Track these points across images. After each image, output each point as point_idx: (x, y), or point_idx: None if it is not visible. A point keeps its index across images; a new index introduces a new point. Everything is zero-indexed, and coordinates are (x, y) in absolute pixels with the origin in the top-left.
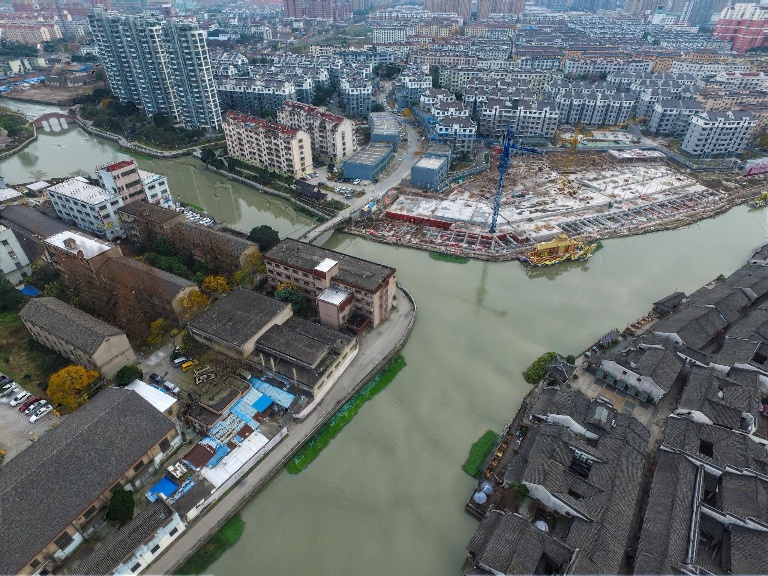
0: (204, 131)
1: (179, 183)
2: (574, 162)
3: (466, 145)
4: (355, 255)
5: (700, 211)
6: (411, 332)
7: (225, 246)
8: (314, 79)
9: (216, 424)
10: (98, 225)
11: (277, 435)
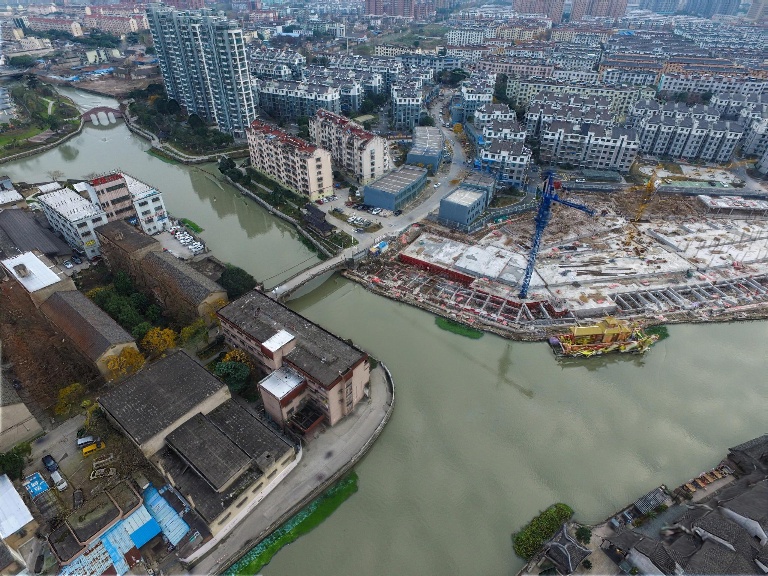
0: (237, 136)
1: (215, 185)
2: (650, 207)
3: (515, 176)
4: (348, 308)
5: None
6: (381, 434)
7: (186, 290)
8: (365, 84)
9: (74, 559)
10: (79, 242)
11: None
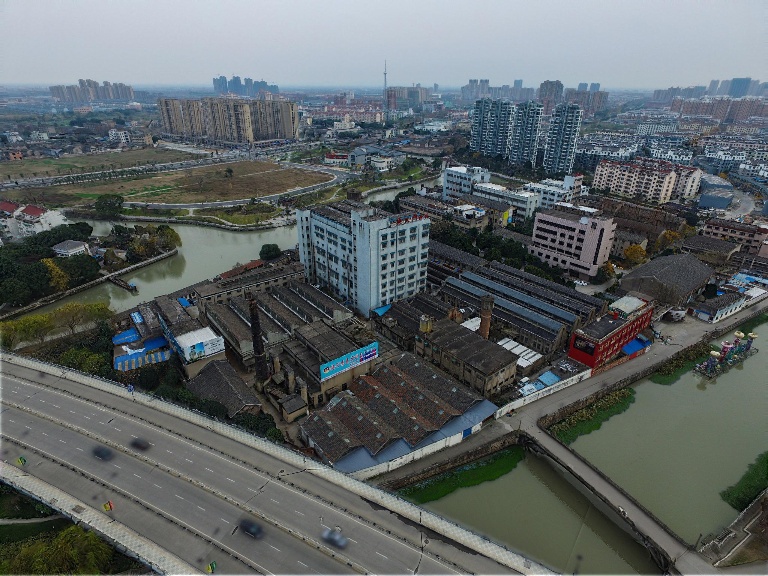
0: None
1: None
2: None
3: None
4: None
5: None
6: None
7: None
8: None
9: (730, 280)
10: None
11: None
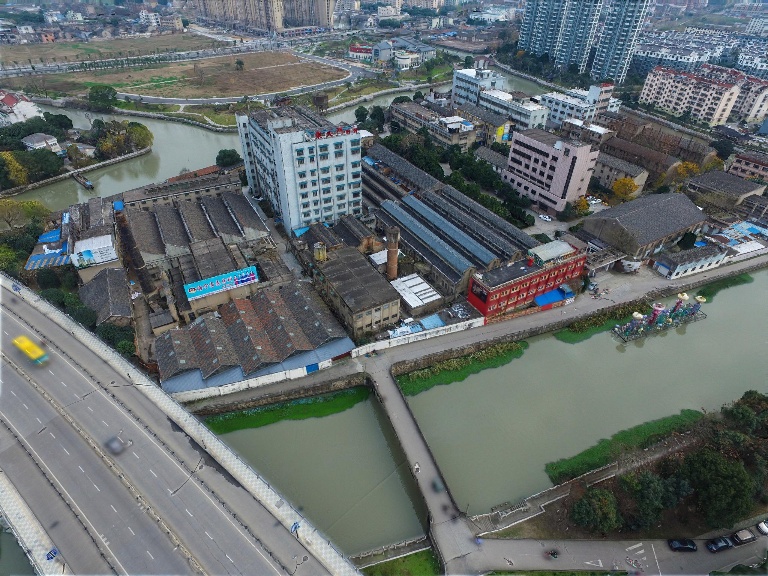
0: None
1: None
2: None
3: None
4: None
5: None
6: None
7: None
8: None
9: (726, 229)
10: None
11: None
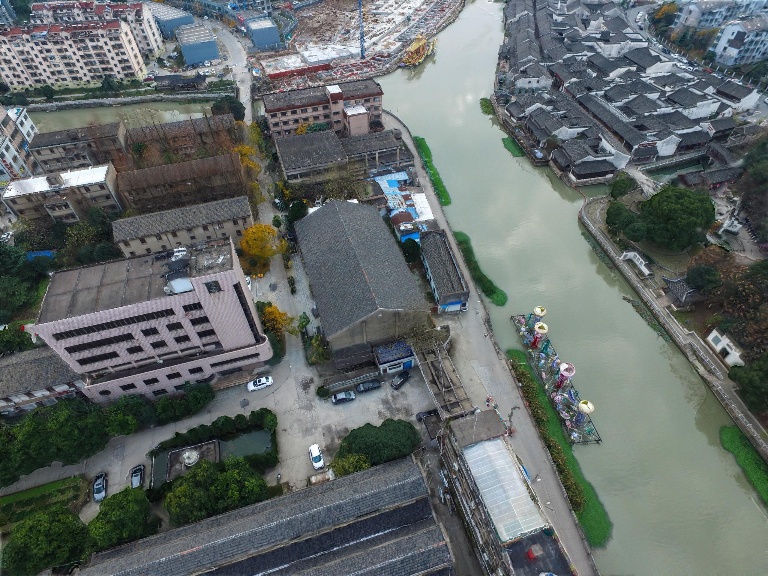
0: None
1: None
2: (349, 1)
3: (266, 6)
4: None
5: (454, 8)
6: None
7: None
8: None
9: (388, 203)
10: (2, 184)
11: (423, 190)
